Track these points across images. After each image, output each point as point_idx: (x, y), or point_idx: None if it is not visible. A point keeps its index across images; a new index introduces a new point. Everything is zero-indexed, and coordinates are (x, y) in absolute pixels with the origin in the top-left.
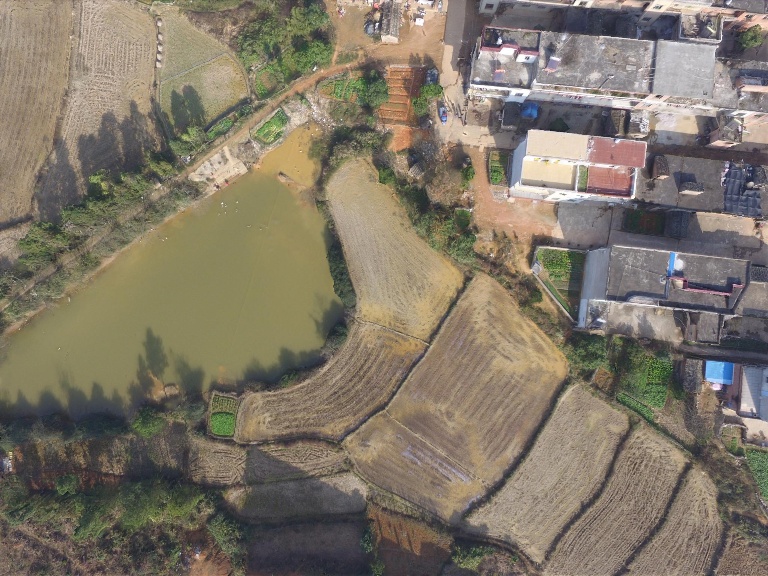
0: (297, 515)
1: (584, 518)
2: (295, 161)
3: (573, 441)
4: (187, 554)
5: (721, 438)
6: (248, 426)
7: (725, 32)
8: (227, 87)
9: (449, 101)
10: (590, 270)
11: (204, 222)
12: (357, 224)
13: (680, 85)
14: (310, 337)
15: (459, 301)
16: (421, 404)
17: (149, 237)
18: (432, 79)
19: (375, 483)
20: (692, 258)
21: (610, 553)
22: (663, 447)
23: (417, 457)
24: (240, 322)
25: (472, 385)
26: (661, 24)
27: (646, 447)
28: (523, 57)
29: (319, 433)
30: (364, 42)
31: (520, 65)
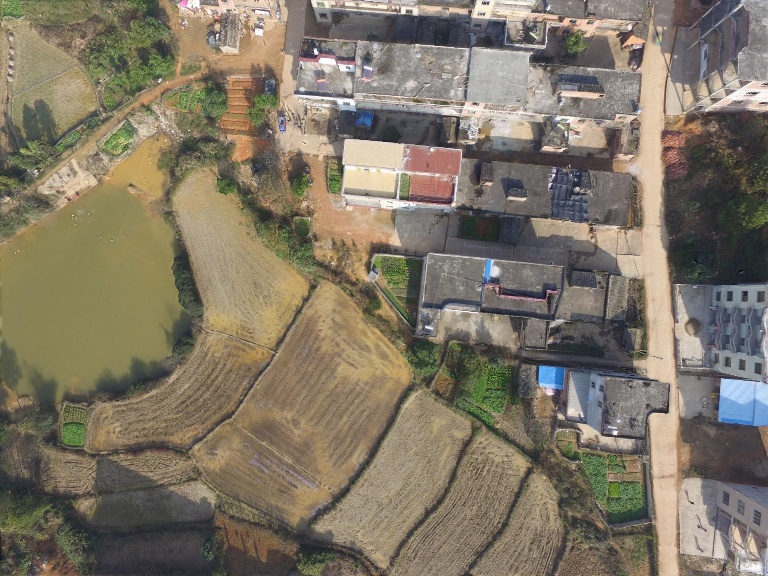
0: (146, 524)
1: (427, 524)
2: (144, 172)
3: (417, 447)
4: (36, 564)
5: (556, 443)
6: (99, 436)
7: (558, 37)
8: (77, 100)
9: (289, 110)
10: (422, 277)
11: (55, 234)
12: (204, 234)
13: (493, 92)
14: (161, 347)
15: (304, 309)
16: (267, 412)
17: (2, 250)
18: (270, 89)
19: (223, 491)
20: (508, 265)
21: (453, 558)
22: (505, 452)
23: (264, 465)
24: (92, 333)
25: (317, 393)
26: (494, 30)
27: (488, 452)
28: (343, 67)
29: (168, 442)
30: (207, 53)
31: (344, 74)
